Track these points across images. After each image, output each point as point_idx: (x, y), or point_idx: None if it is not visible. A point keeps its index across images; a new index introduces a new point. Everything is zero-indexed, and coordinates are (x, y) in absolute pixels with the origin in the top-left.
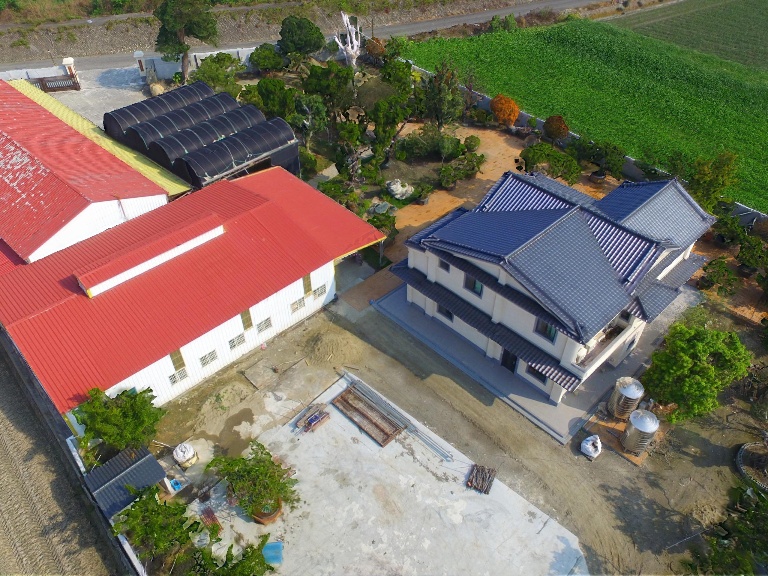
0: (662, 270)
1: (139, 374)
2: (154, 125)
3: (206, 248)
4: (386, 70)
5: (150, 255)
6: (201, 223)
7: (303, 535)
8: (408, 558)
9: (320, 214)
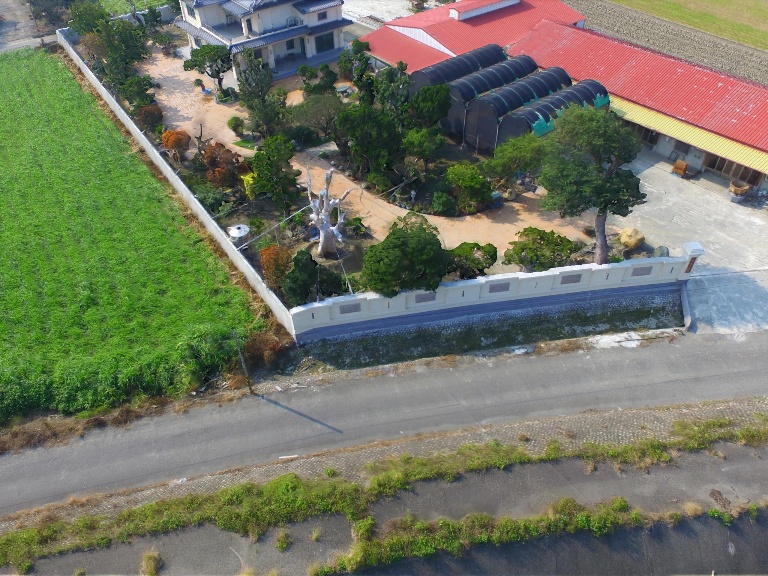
0: None
1: None
2: None
3: None
4: (286, 184)
5: None
6: None
7: (405, 4)
8: (369, 1)
9: (391, 48)
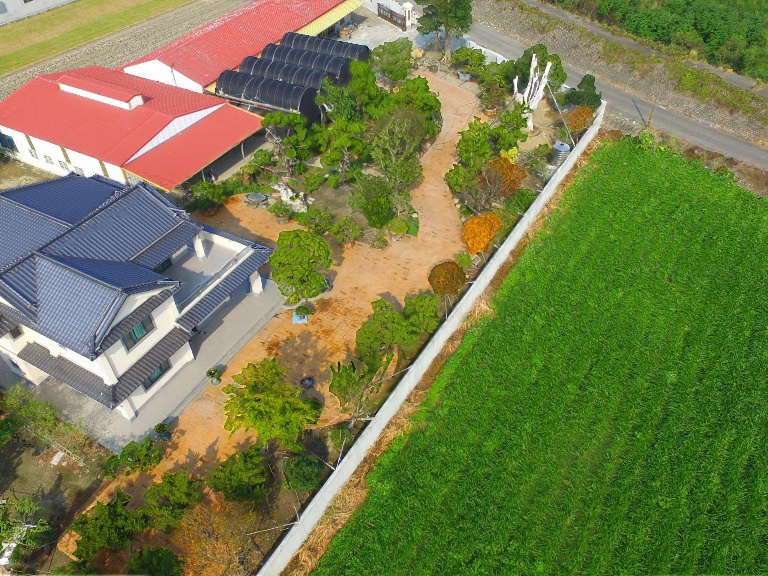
0: (3, 312)
1: (12, 131)
2: (278, 50)
3: (114, 109)
4: None
5: (87, 88)
6: (122, 93)
7: None
8: None
9: (193, 152)
